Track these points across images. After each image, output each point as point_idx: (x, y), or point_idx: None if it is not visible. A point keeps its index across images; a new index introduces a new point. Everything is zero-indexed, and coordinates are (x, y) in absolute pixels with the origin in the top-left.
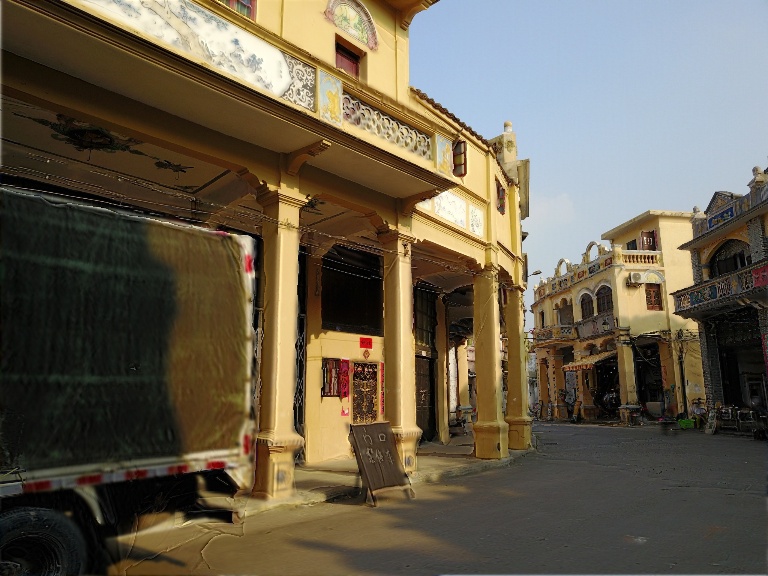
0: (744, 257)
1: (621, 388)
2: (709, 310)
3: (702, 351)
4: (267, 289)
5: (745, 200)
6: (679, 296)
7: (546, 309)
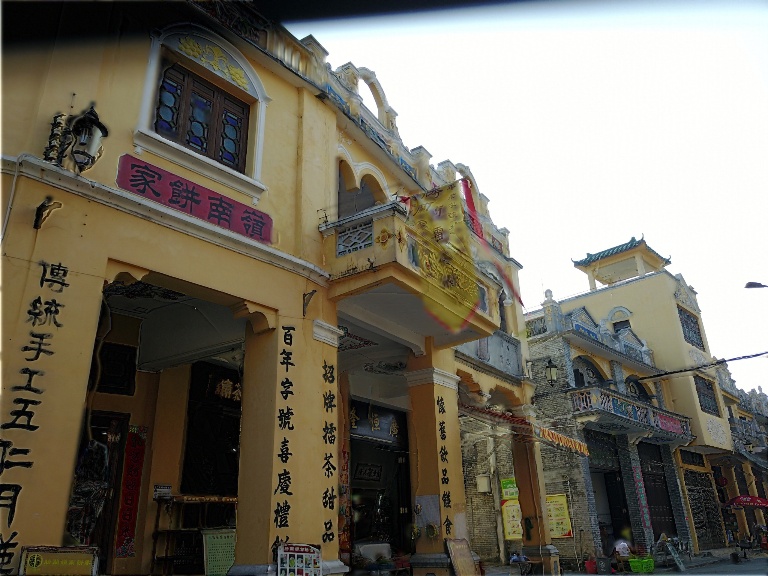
0: (584, 380)
1: (544, 506)
2: (613, 424)
3: (585, 466)
4: None
5: (605, 339)
6: None
7: (314, 132)
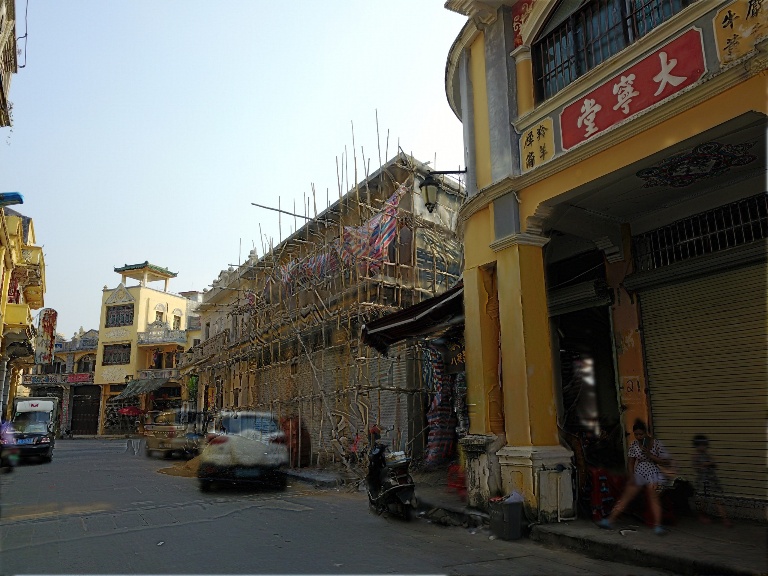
0: (60, 365)
1: None
2: None
3: None
4: (9, 396)
5: (69, 344)
6: (26, 377)
7: None
